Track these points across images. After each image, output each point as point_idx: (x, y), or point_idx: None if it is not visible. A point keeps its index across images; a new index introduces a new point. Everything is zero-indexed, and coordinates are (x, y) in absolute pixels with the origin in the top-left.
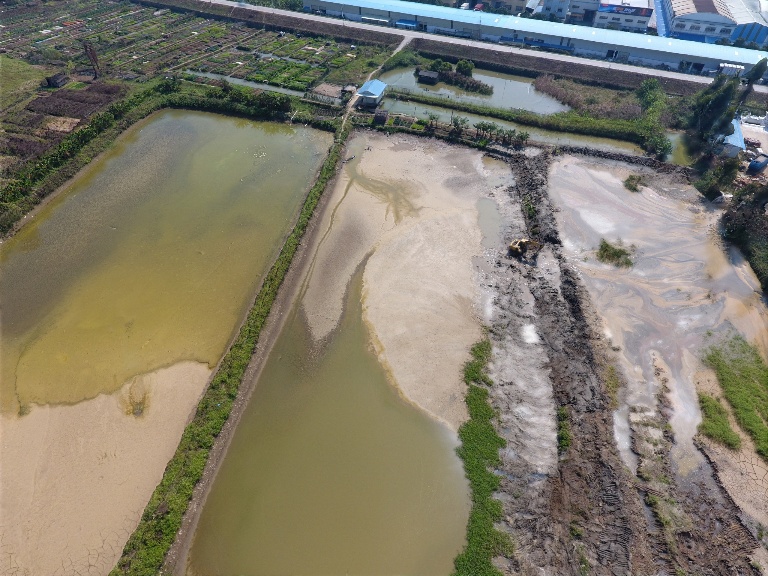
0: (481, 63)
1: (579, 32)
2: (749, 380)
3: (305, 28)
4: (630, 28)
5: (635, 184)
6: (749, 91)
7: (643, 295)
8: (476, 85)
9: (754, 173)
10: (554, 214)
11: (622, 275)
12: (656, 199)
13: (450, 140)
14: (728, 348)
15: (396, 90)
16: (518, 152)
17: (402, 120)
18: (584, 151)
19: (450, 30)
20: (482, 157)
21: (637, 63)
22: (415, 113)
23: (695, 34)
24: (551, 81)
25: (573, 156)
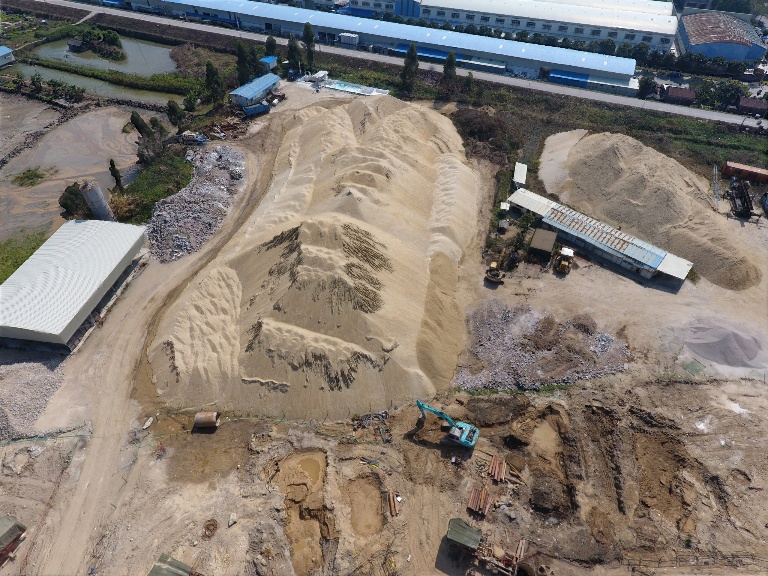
0: (143, 34)
1: (243, 7)
2: (3, 260)
3: (15, 5)
4: (320, 5)
5: (132, 127)
6: (311, 53)
7: (10, 205)
8: (110, 52)
9: (246, 118)
10: (25, 149)
11: (15, 192)
12: (133, 138)
13: (30, 96)
14: (23, 240)
15: (29, 56)
16: (72, 104)
17: (2, 80)
18: (127, 103)
19: (149, 7)
20: (45, 109)
21: (283, 34)
22: (28, 75)
23: (368, 10)
24: (189, 49)
25: (116, 107)
